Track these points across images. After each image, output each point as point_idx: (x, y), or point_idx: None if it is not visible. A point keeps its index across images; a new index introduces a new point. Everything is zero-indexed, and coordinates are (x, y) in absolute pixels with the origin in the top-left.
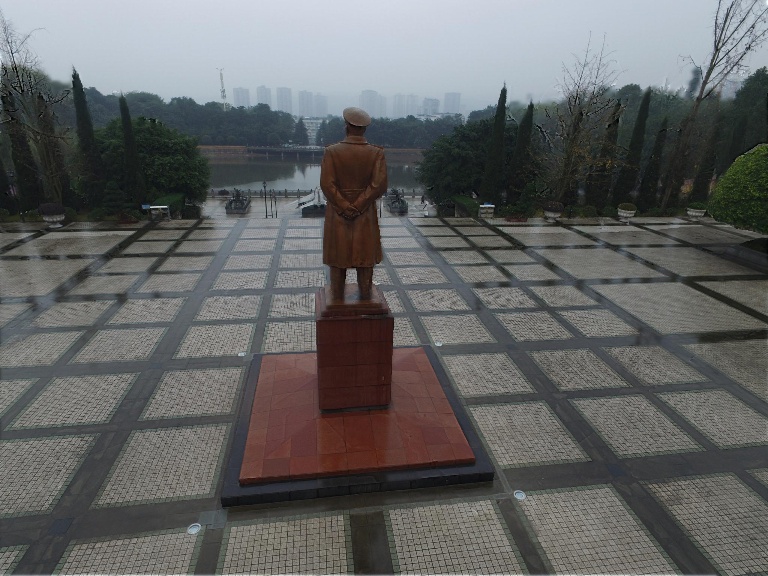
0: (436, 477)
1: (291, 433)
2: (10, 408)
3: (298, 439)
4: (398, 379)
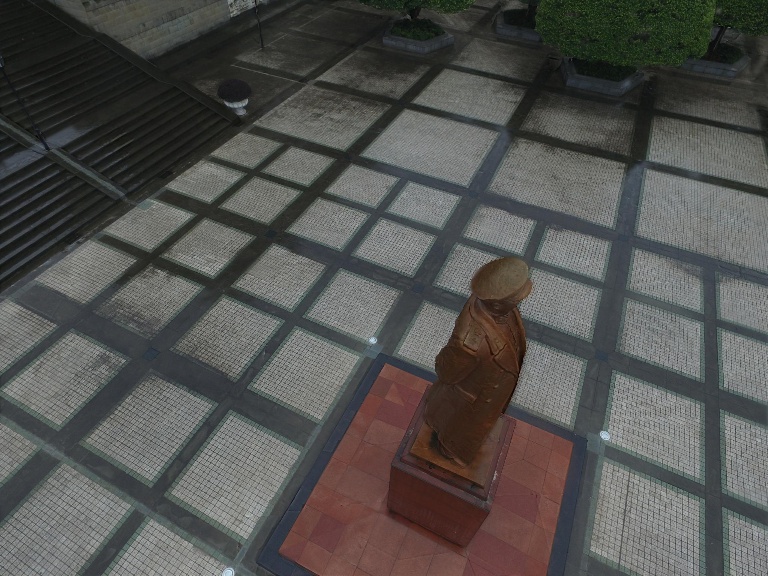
0: (292, 501)
1: (410, 408)
2: (561, 268)
3: (399, 410)
4: (440, 565)
